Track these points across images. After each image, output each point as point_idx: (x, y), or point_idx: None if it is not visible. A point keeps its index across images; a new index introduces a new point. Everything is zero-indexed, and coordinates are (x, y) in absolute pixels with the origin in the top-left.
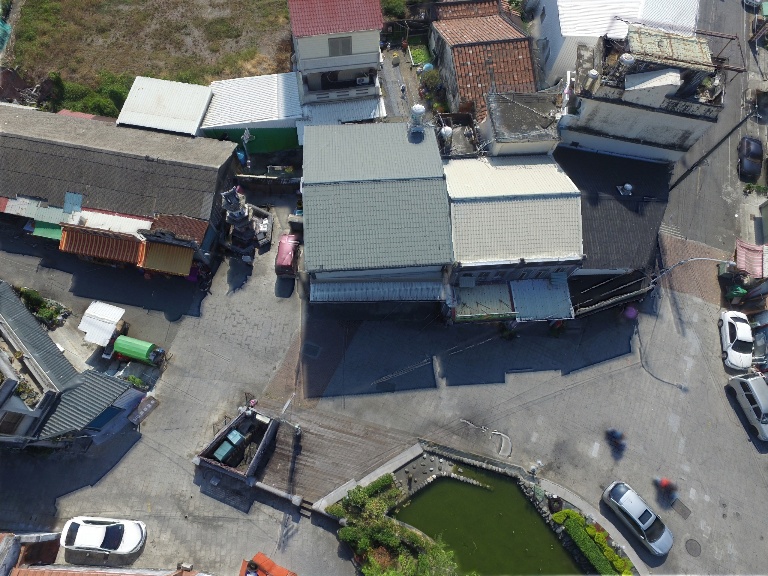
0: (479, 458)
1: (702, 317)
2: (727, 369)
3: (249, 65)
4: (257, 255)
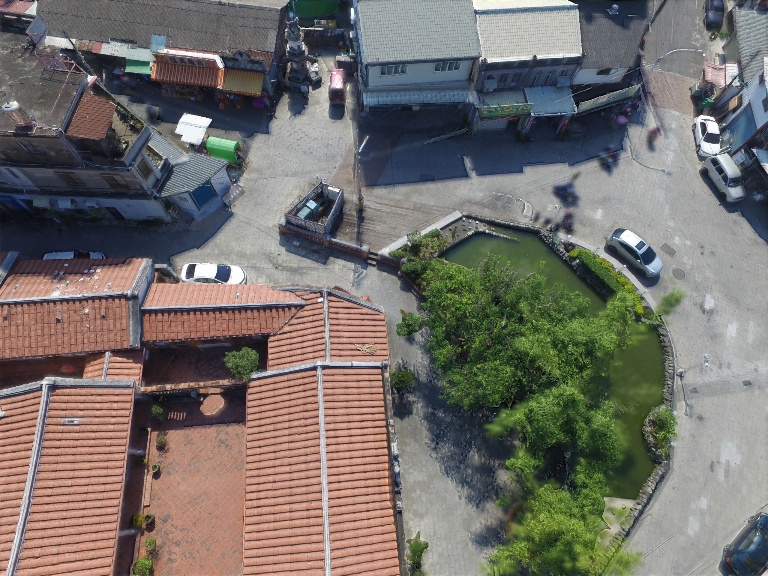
0: None
1: (679, 124)
2: (700, 158)
3: None
4: (311, 91)
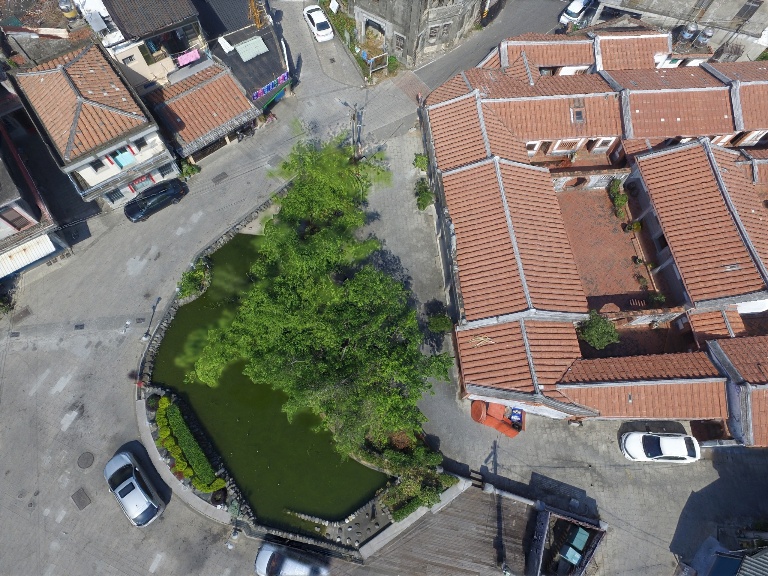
0: (295, 545)
1: None
2: None
3: None
4: None
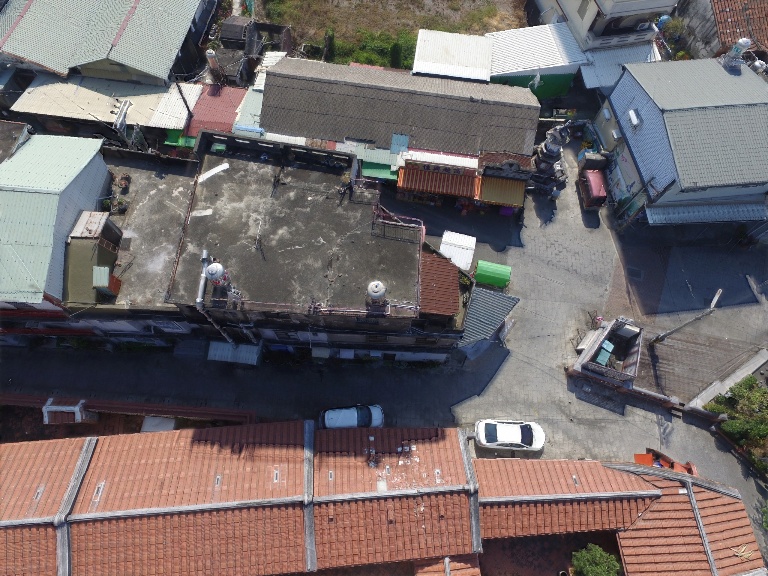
0: None
1: None
2: None
3: (495, 21)
4: None
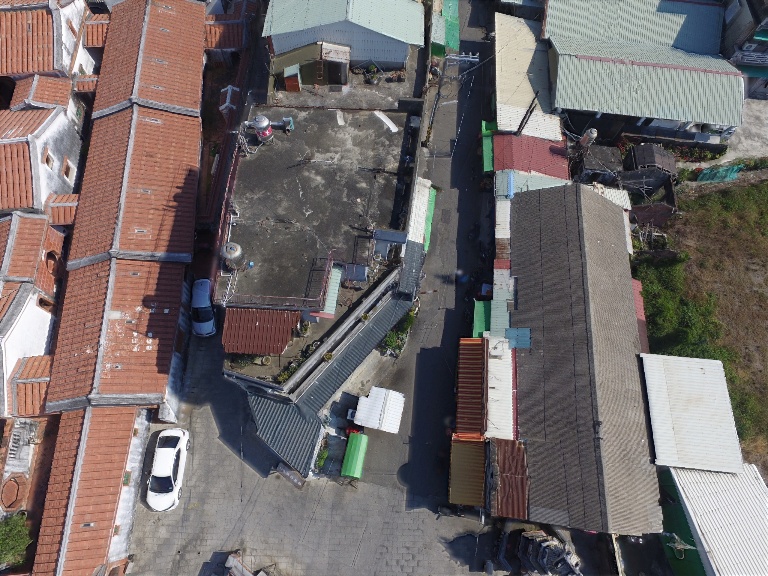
0: None
1: None
2: None
3: None
4: (500, 574)
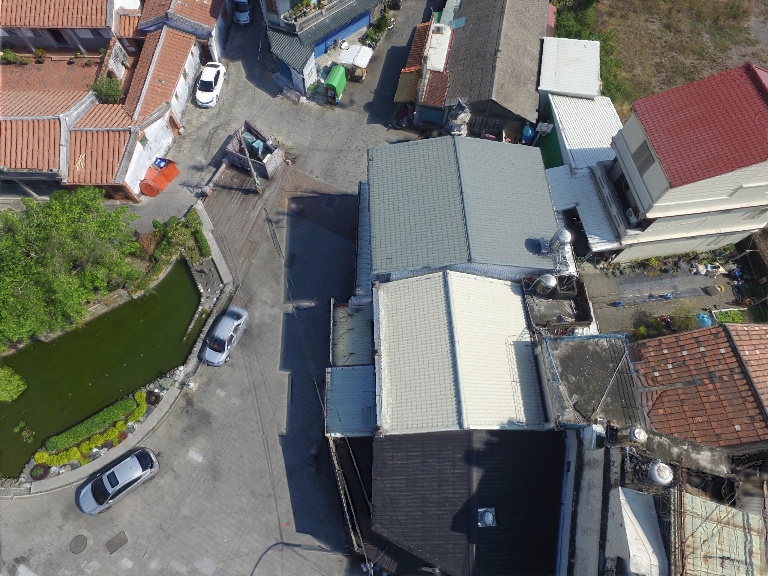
0: (212, 336)
1: None
2: None
3: None
4: None
